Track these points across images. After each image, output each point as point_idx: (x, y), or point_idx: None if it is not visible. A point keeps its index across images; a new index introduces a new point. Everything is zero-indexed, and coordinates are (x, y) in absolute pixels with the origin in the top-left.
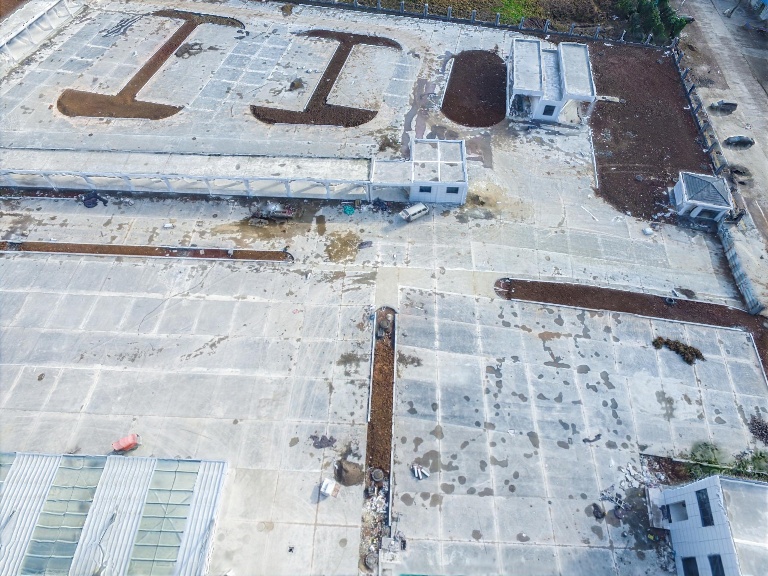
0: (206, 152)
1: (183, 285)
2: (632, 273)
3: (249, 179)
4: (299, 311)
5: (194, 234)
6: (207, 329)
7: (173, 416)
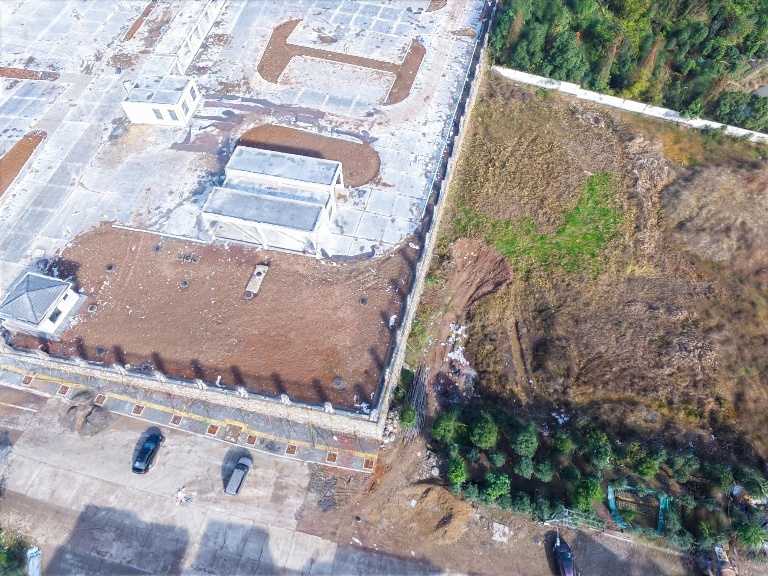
0: (249, 4)
1: (127, 4)
2: (4, 225)
3: (183, 5)
4: (79, 43)
5: (168, 5)
6: (89, 14)
7: (40, 7)
